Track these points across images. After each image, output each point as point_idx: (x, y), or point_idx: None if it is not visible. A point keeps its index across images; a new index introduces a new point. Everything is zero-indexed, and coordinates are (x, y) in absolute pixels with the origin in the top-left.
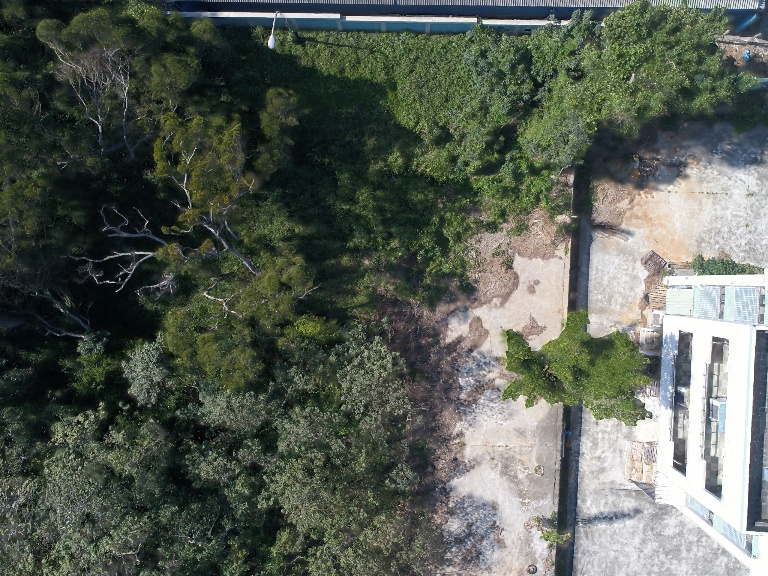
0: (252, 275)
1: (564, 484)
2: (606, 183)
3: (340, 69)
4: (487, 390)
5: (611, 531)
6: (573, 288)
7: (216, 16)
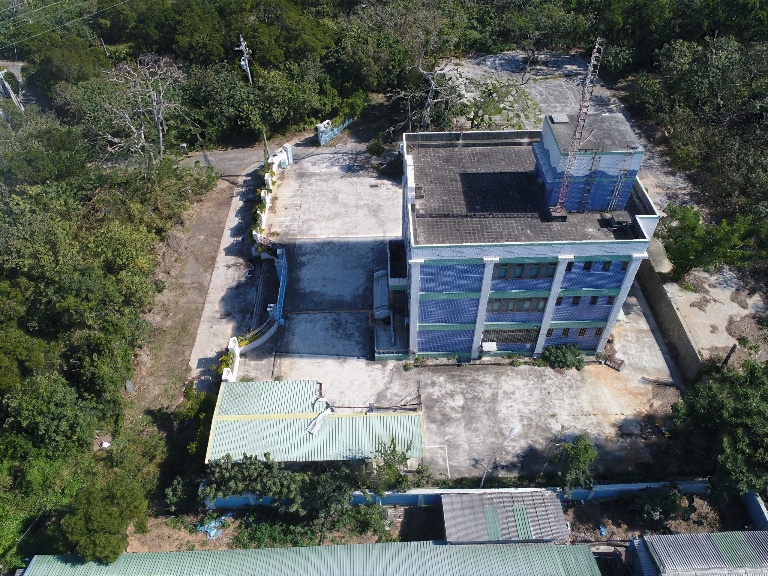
0: None
1: None
2: None
3: None
4: (712, 271)
5: None
6: (669, 345)
7: None
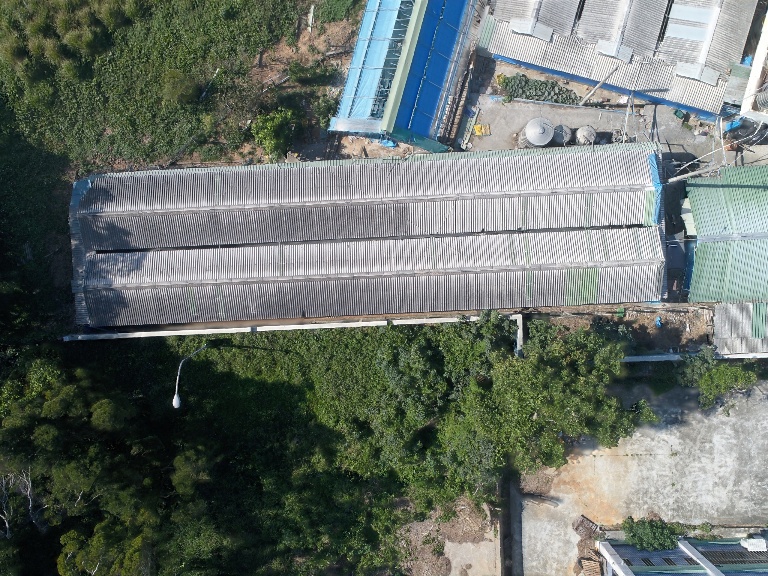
0: None
1: None
2: None
3: (257, 373)
4: None
5: None
6: (508, 555)
7: (127, 337)
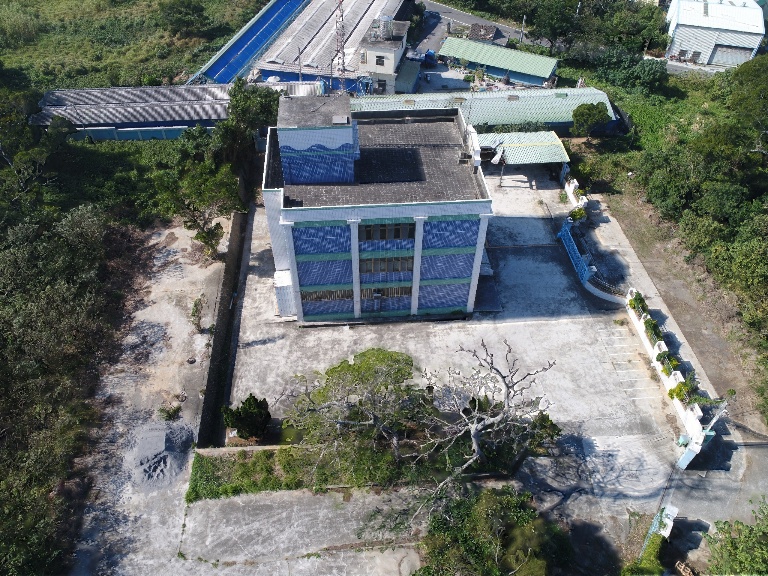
0: (13, 160)
1: (230, 325)
2: None
3: (112, 148)
4: (172, 264)
5: (265, 348)
6: (244, 231)
7: None
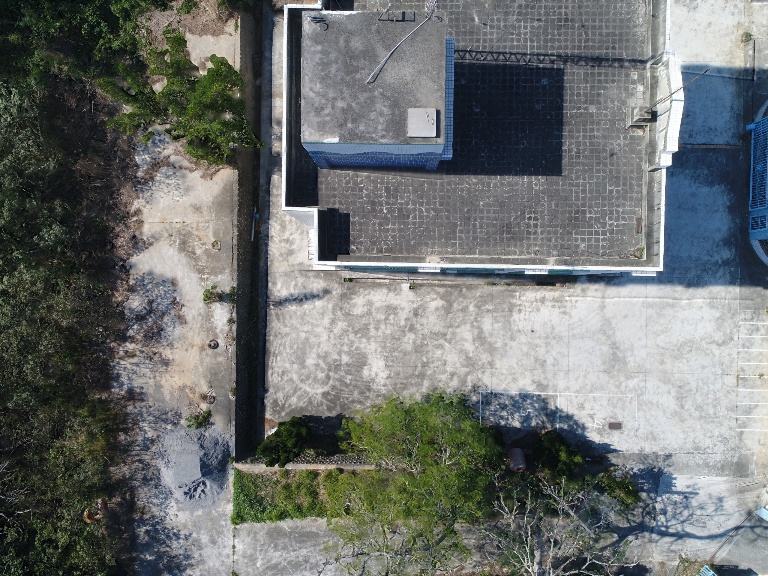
0: None
1: (255, 268)
2: None
3: None
4: (163, 167)
5: (301, 312)
6: (258, 74)
7: None
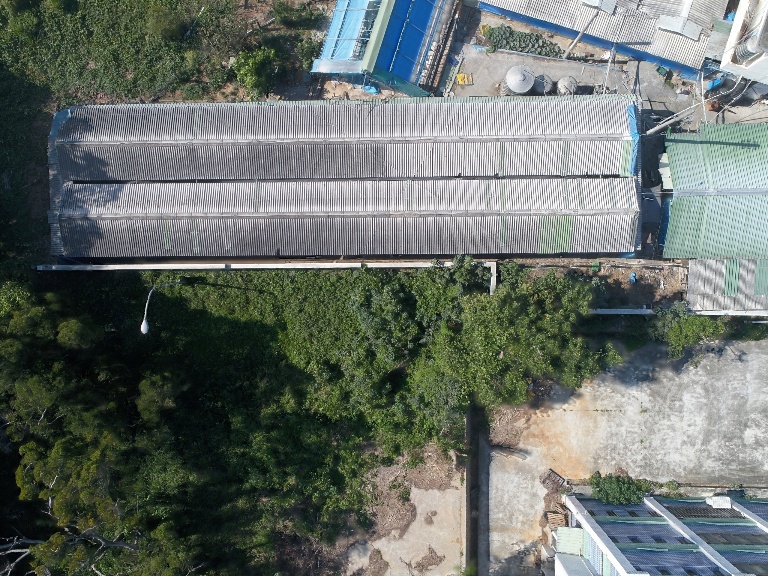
0: (128, 573)
1: None
2: (501, 405)
3: (230, 311)
4: None
5: None
6: (474, 506)
7: (101, 269)
